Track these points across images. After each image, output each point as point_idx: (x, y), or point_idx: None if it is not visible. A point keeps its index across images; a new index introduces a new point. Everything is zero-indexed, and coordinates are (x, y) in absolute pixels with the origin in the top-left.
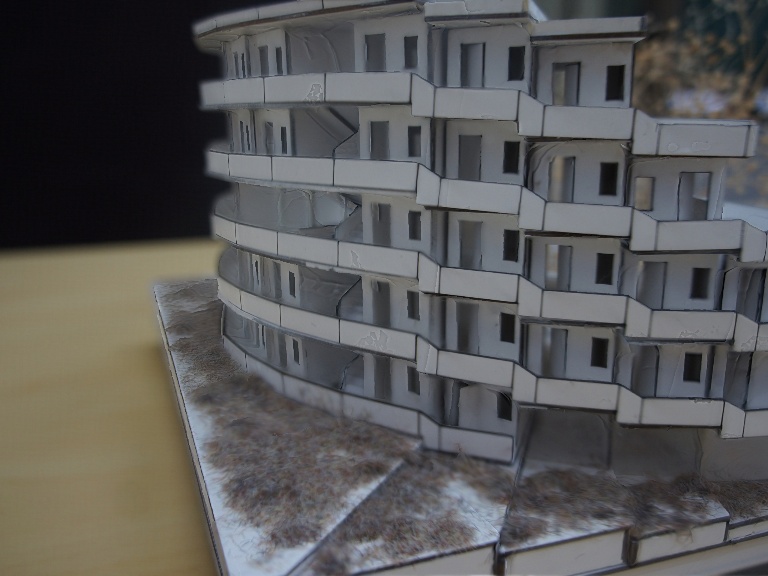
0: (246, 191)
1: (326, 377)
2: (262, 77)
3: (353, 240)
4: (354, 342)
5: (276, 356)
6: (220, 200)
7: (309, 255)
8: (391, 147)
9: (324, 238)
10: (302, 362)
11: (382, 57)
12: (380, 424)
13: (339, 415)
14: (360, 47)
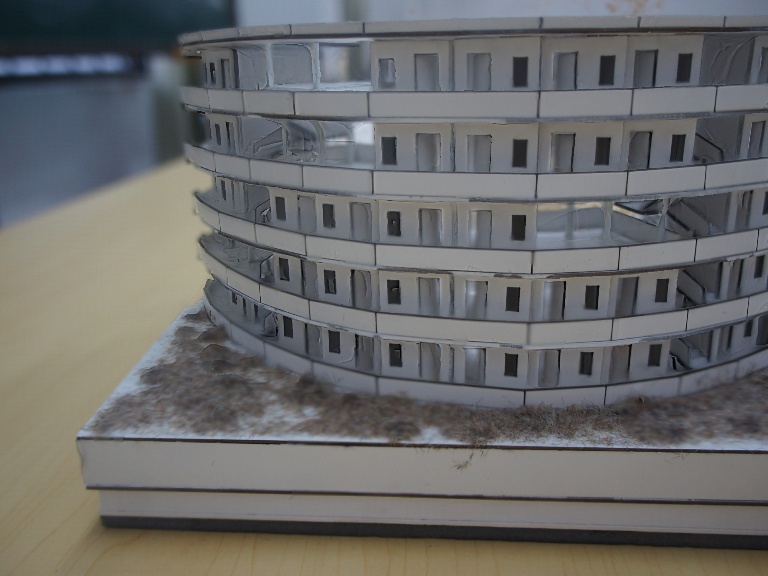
0: (540, 215)
1: (669, 366)
2: (715, 86)
3: (712, 230)
4: (756, 311)
5: (603, 377)
6: (399, 243)
7: (729, 250)
8: (765, 142)
9: (745, 231)
10: (667, 361)
11: (764, 67)
12: (760, 368)
13: (733, 381)
14: (757, 58)
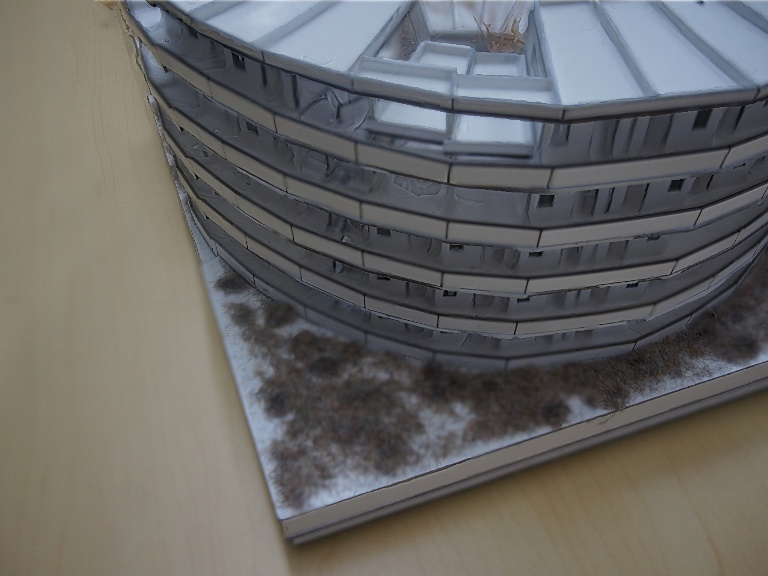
0: None
1: None
2: None
3: None
4: None
5: None
6: (551, 273)
7: None
8: None
9: None
10: None
11: None
12: None
13: (759, 259)
14: None
